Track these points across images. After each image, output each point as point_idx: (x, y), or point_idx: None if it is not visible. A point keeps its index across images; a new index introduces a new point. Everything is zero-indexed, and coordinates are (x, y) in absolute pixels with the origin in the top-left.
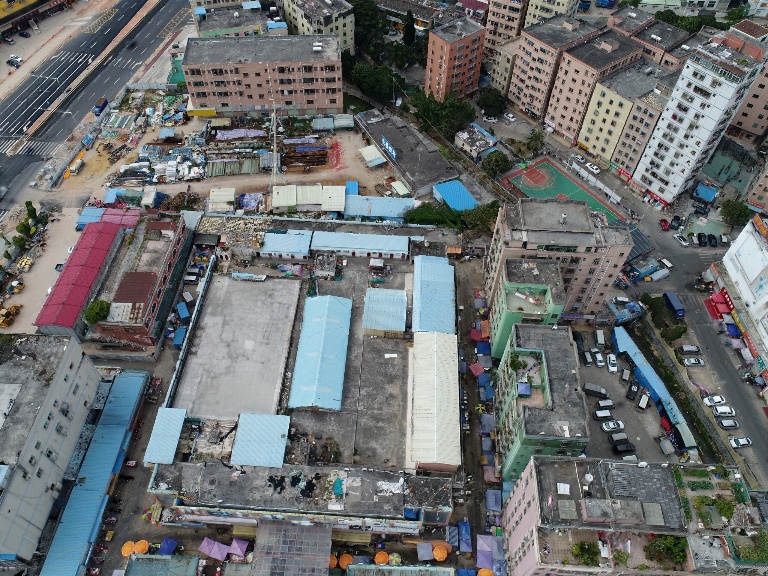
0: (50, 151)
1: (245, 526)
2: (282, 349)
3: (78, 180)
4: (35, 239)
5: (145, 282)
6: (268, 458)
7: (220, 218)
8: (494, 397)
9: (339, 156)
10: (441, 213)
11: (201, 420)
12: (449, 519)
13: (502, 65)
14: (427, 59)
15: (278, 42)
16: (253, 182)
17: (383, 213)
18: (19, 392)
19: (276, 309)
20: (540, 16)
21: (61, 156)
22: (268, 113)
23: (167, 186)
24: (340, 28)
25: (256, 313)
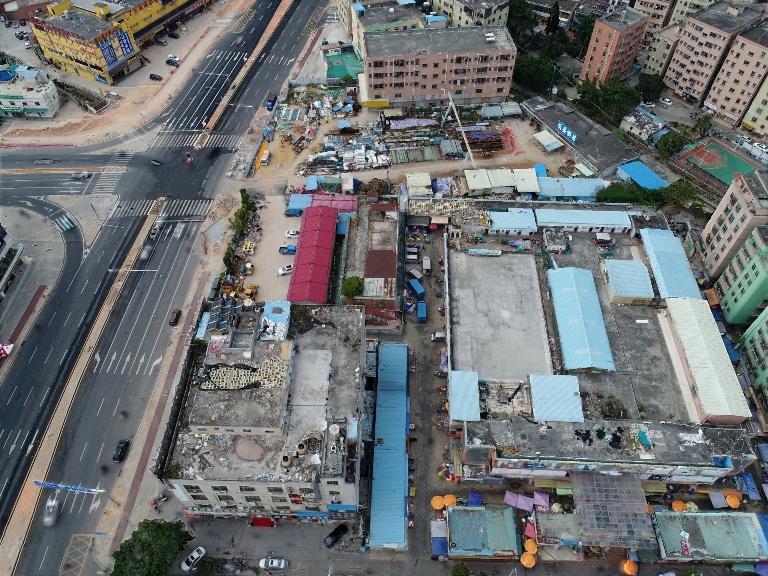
0: (234, 143)
1: (545, 479)
2: (538, 317)
3: (269, 170)
4: (255, 224)
5: (390, 259)
6: (569, 414)
7: (426, 201)
8: (744, 358)
9: (513, 142)
10: (634, 192)
11: (486, 382)
12: (743, 468)
13: (659, 51)
14: (588, 47)
15: (449, 34)
16: (438, 168)
17: (576, 193)
18: (332, 357)
19: (520, 281)
20: (692, 4)
21: (246, 148)
22: (435, 103)
23: (357, 173)
24: (496, 20)
25: (502, 285)
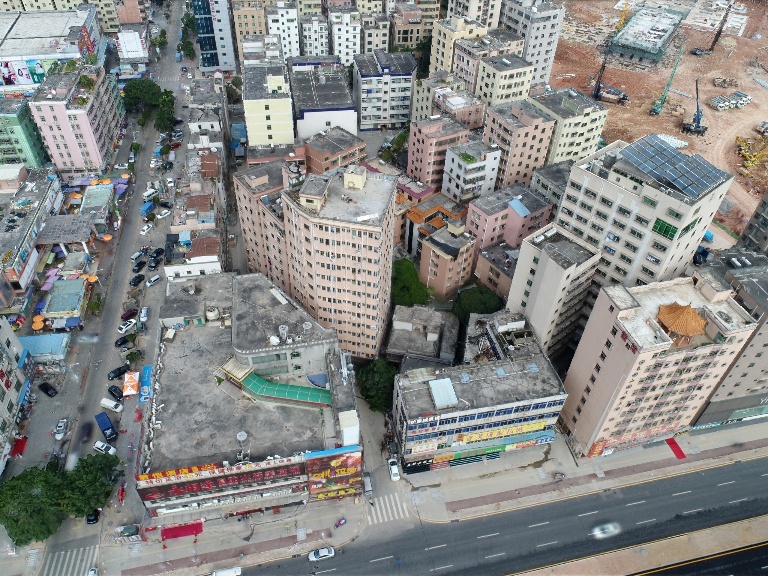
0: None
1: (38, 266)
2: None
3: None
4: None
5: None
6: None
7: None
8: None
9: None
10: None
11: None
12: None
13: None
14: None
15: None
16: None
17: None
18: None
19: None
20: None
21: None
22: None
23: None
24: None
25: None
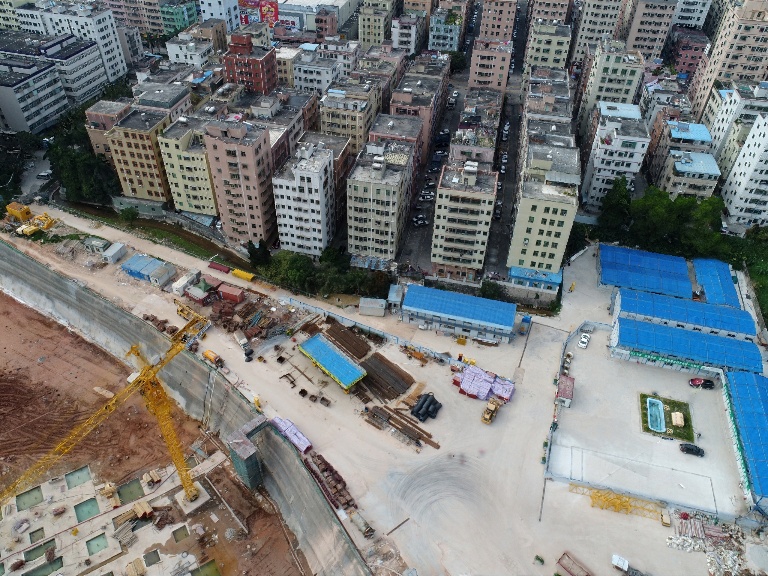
0: None
1: None
2: None
3: None
4: None
5: None
6: None
7: None
8: None
9: None
10: None
11: None
12: None
13: None
14: None
15: None
16: None
17: None
18: None
19: None
20: None
21: None
22: None
23: None
24: None
25: None
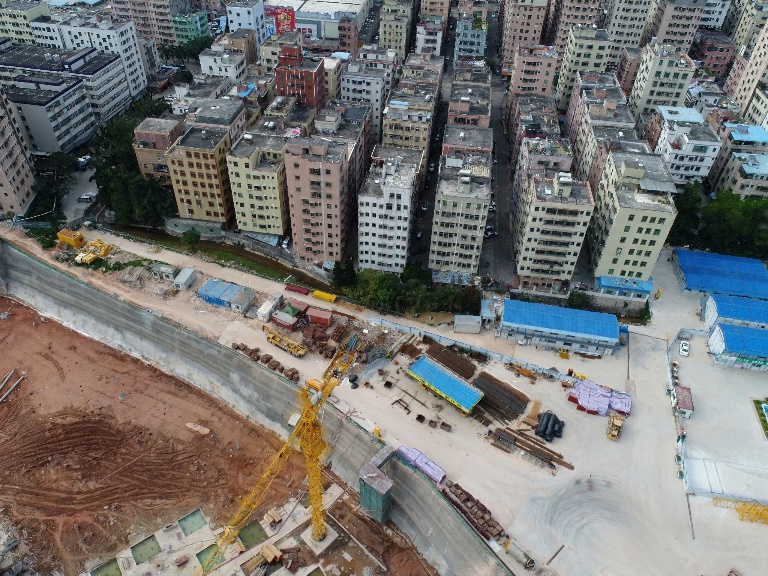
0: None
1: None
2: None
3: None
4: None
5: None
6: (58, 4)
7: None
8: None
9: None
10: None
11: None
12: None
13: None
14: None
15: None
16: None
17: None
18: None
19: None
20: None
21: None
22: None
23: None
24: None
25: None
